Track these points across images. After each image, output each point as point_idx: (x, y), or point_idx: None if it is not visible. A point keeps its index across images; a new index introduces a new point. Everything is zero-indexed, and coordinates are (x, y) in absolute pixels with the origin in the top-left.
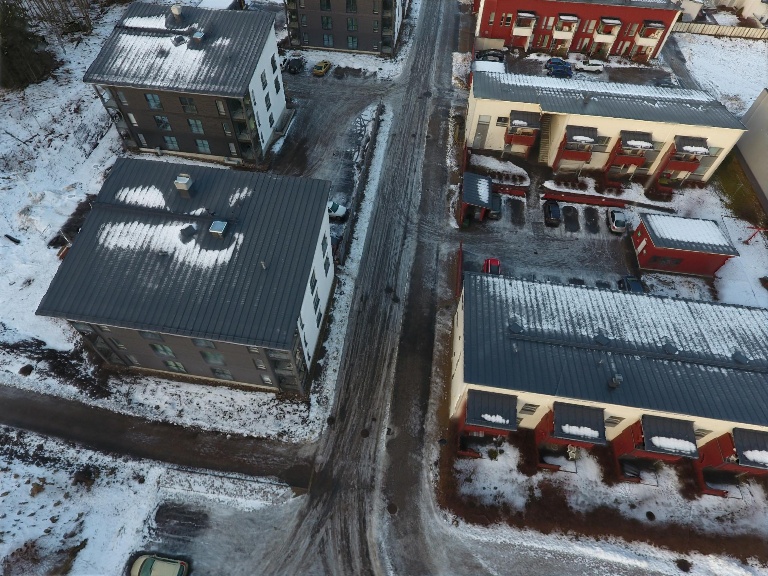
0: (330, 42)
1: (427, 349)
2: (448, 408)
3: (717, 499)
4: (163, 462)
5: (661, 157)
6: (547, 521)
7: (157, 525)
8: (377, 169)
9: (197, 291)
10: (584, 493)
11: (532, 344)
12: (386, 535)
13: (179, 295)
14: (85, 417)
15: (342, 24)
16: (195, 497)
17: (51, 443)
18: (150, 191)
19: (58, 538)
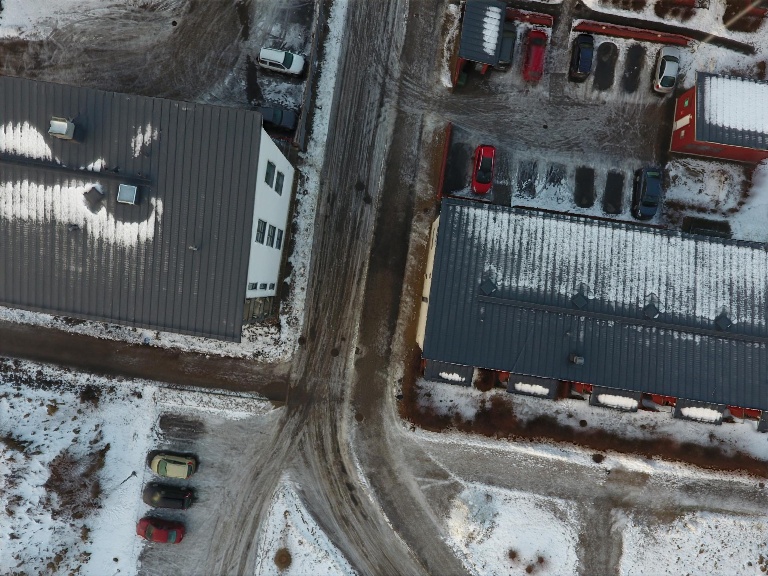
0: None
1: (399, 264)
2: (416, 329)
3: (648, 412)
4: (154, 381)
5: None
6: (492, 427)
7: (163, 431)
8: None
9: (127, 276)
10: (530, 405)
11: (502, 308)
12: (354, 438)
13: (108, 281)
14: (69, 344)
15: None
16: (189, 410)
17: (48, 369)
18: (25, 132)
19: (85, 445)
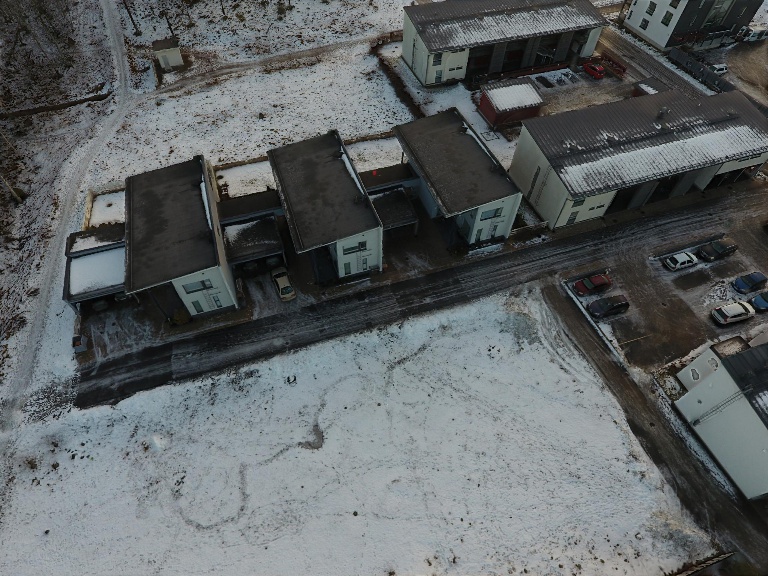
0: None
1: None
2: None
3: None
4: None
5: None
6: None
7: None
8: None
9: None
10: None
11: None
12: None
13: None
14: None
15: None
16: None
17: None
18: None
19: None
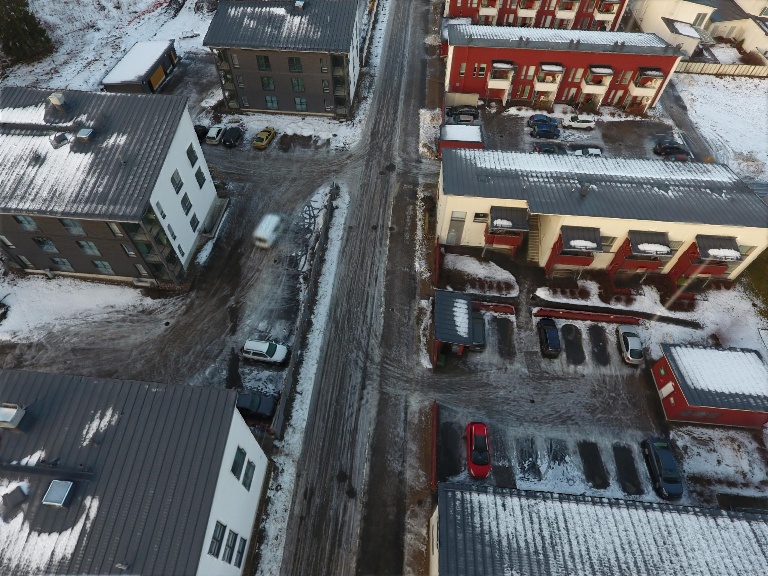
0: (274, 104)
1: None
2: None
3: None
4: None
5: (679, 256)
6: None
7: None
8: (329, 281)
9: None
10: None
11: None
12: None
13: None
14: None
15: (286, 84)
16: None
17: None
18: None
19: None
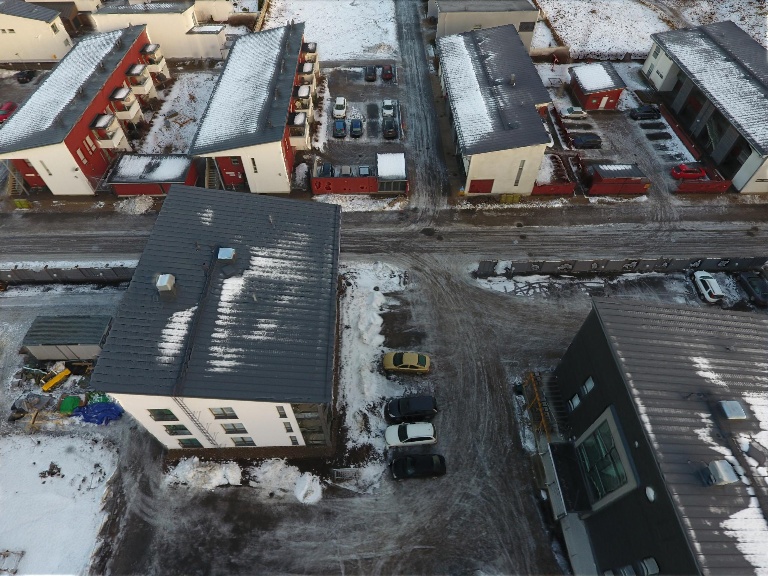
0: None
1: None
2: None
3: None
4: None
5: None
6: None
7: None
8: None
9: None
10: None
11: None
12: None
13: None
14: None
15: None
16: None
17: None
18: None
19: None
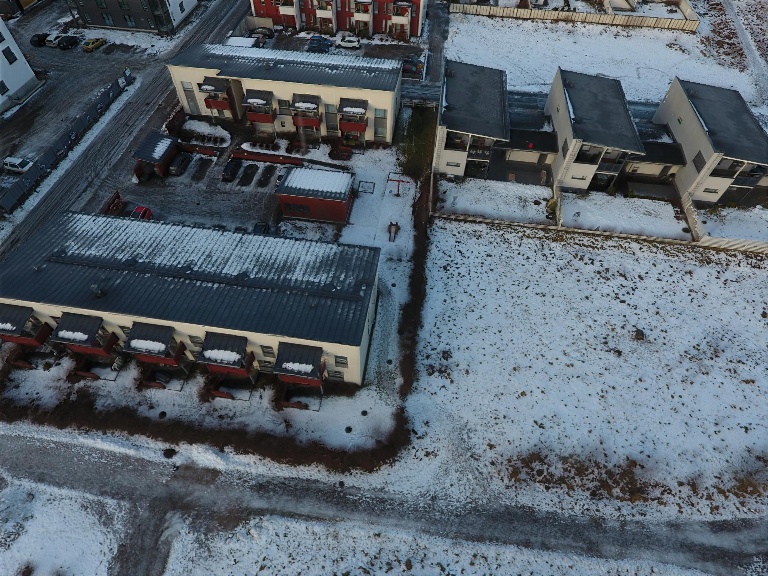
0: (110, 21)
1: None
2: None
3: (227, 401)
4: None
5: None
6: None
7: None
8: (94, 133)
9: None
10: (114, 397)
11: (61, 265)
12: None
13: None
14: None
15: (114, 3)
16: None
17: None
18: None
19: None
